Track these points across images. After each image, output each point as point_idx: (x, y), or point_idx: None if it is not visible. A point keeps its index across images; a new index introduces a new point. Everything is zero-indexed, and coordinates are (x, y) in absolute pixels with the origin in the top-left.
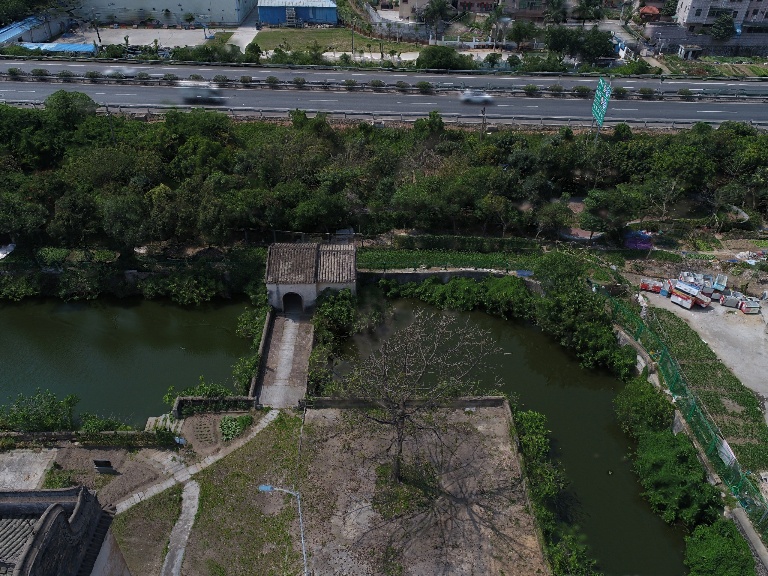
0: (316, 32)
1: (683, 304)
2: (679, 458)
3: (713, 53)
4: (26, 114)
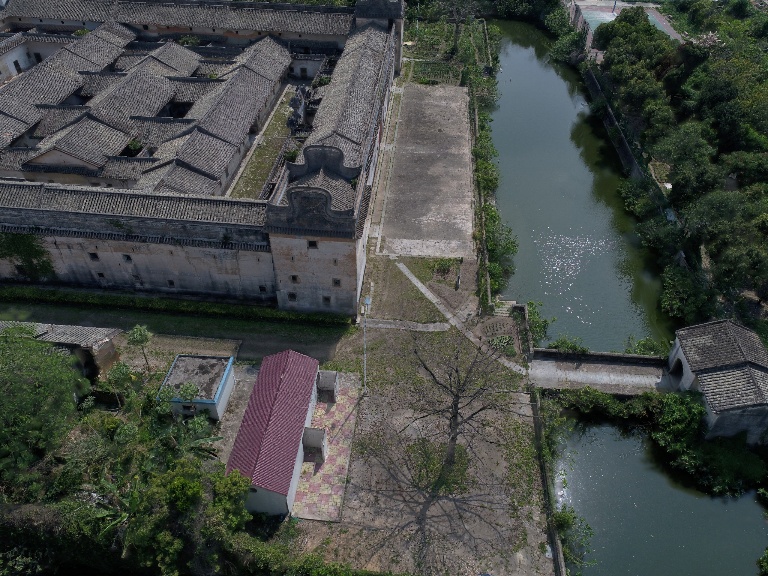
0: None
1: None
2: None
3: None
4: None
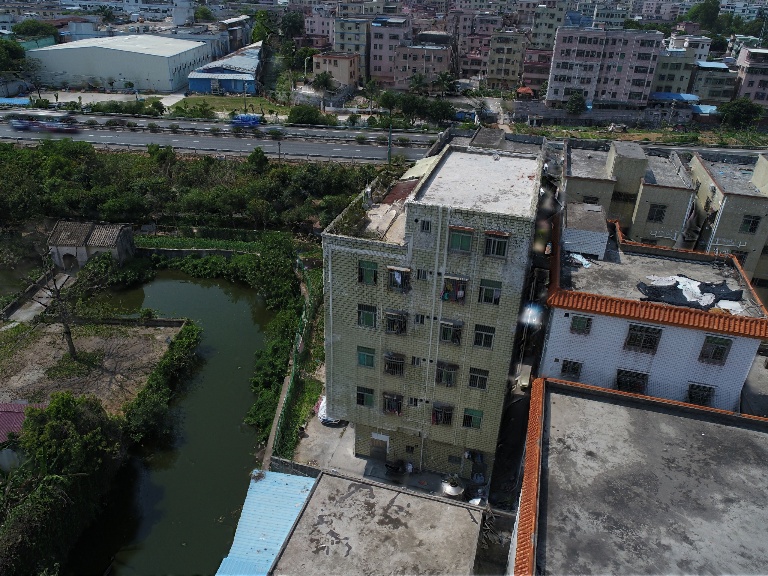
0: (233, 99)
1: None
2: (274, 351)
3: (570, 125)
4: None
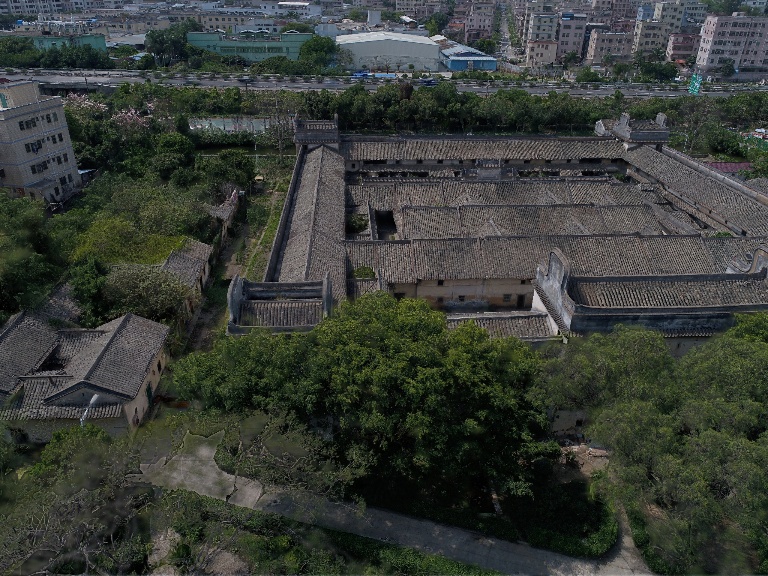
0: None
1: (759, 137)
2: None
3: None
4: (440, 89)
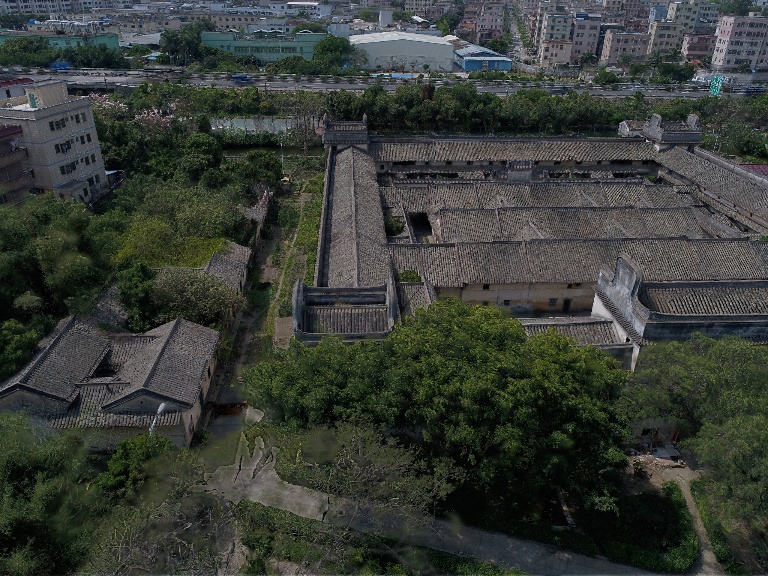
0: None
1: None
2: None
3: None
4: None
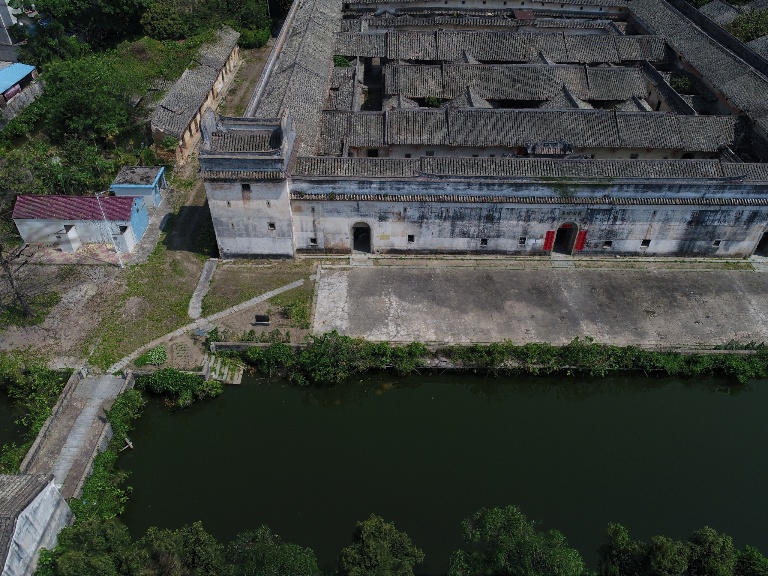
0: None
1: None
2: None
3: None
4: None
